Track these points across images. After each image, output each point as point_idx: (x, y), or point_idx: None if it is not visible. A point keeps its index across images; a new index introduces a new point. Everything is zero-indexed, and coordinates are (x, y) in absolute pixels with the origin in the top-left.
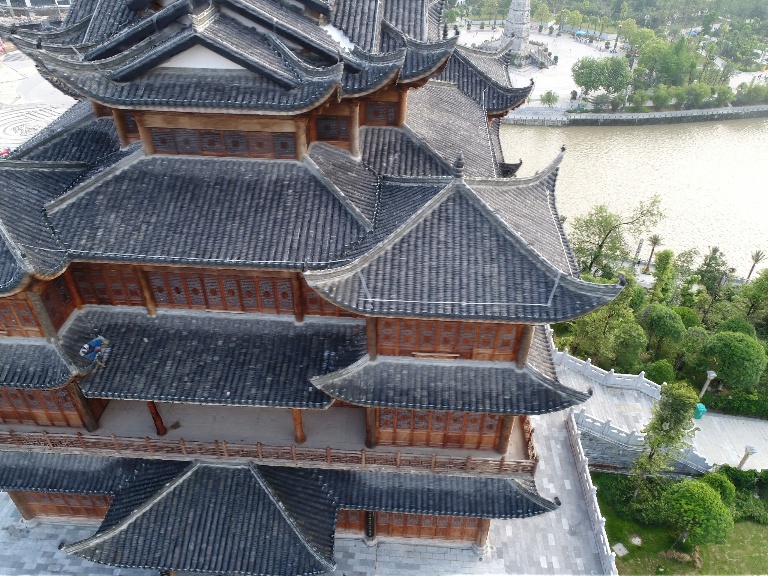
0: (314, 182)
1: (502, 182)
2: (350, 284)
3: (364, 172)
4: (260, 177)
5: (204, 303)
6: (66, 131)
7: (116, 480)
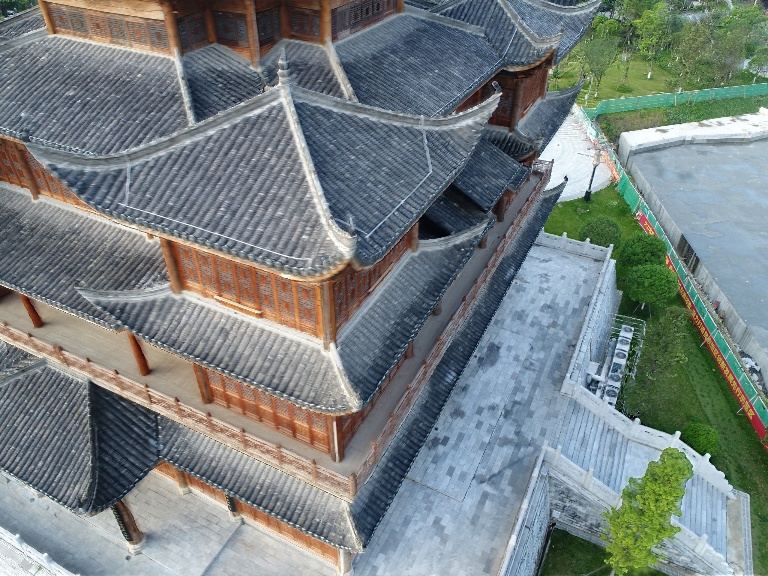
0: None
1: None
2: None
3: None
4: None
5: None
6: (431, 17)
7: None
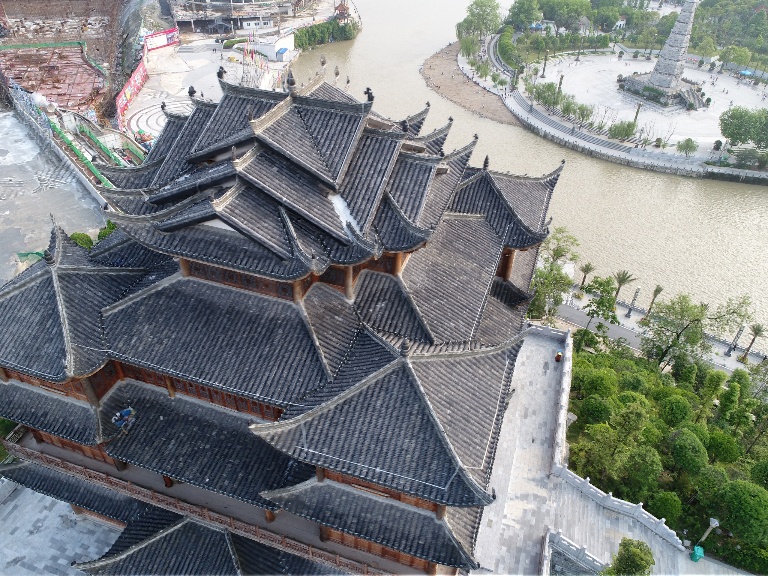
0: (301, 326)
1: (456, 354)
2: (292, 434)
3: (351, 316)
4: (261, 313)
5: (209, 397)
6: None
7: (131, 512)
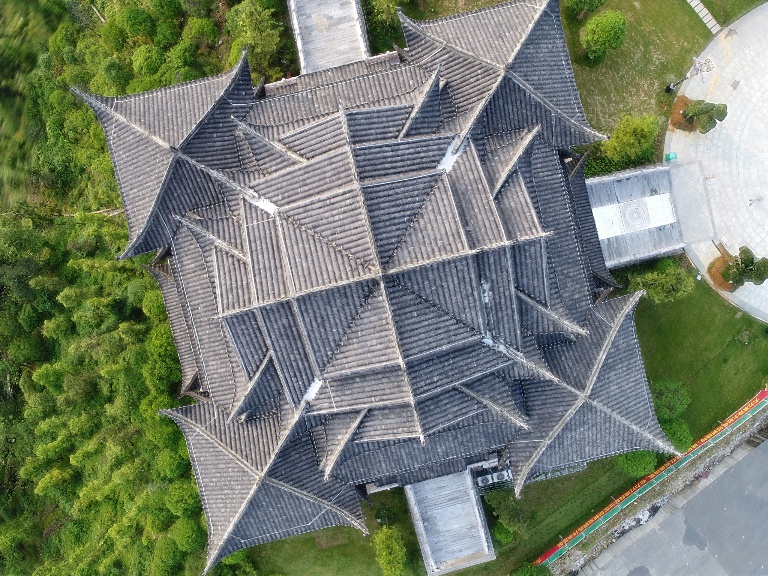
0: None
1: None
2: None
3: None
4: None
5: None
6: None
7: None
